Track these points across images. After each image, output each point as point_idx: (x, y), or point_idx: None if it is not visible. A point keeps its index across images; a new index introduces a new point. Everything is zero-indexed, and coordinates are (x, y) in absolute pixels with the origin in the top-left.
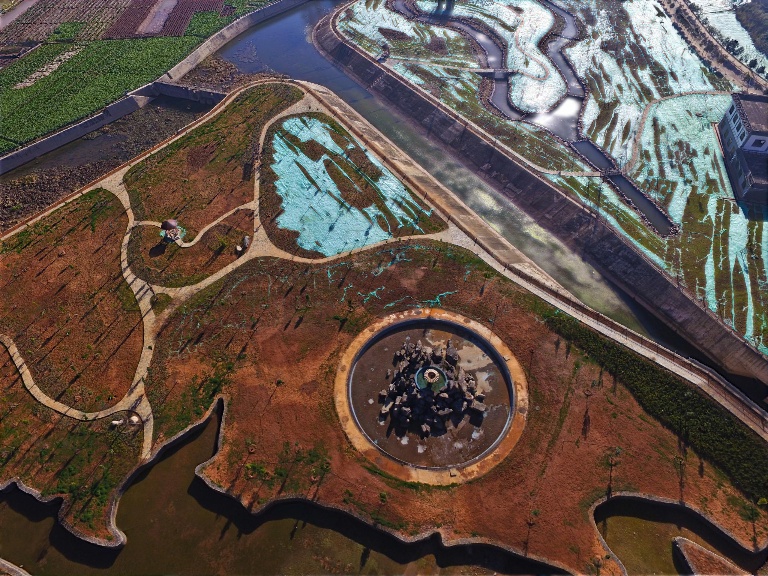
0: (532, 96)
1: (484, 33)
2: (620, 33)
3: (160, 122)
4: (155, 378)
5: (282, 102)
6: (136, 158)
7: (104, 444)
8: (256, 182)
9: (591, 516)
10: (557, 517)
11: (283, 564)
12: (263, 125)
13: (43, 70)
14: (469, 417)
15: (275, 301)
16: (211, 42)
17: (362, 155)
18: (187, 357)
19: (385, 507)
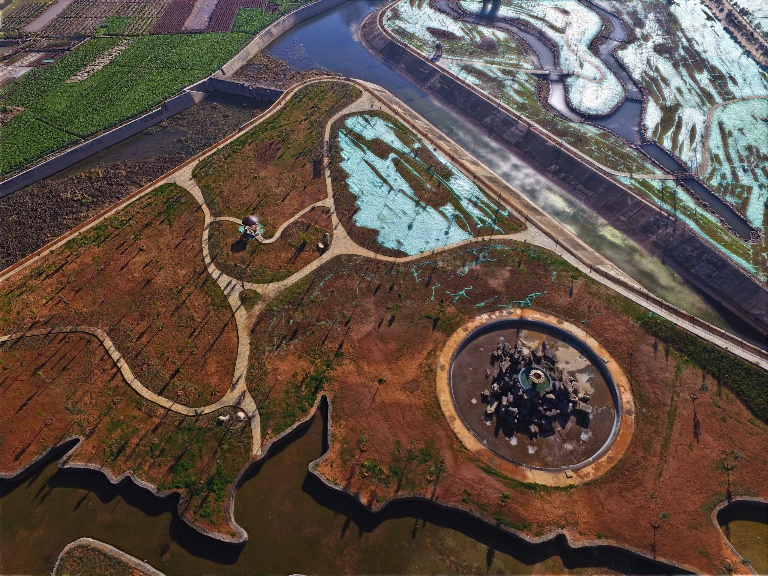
0: (591, 98)
1: (533, 34)
2: (672, 36)
3: (218, 118)
4: (255, 374)
5: (341, 100)
6: (202, 153)
7: (213, 439)
8: (328, 179)
9: (714, 520)
10: (681, 520)
11: (409, 563)
12: (326, 123)
13: (95, 64)
14: (575, 418)
15: (365, 299)
16: (260, 39)
17: (430, 154)
18: (284, 354)
19: (506, 507)
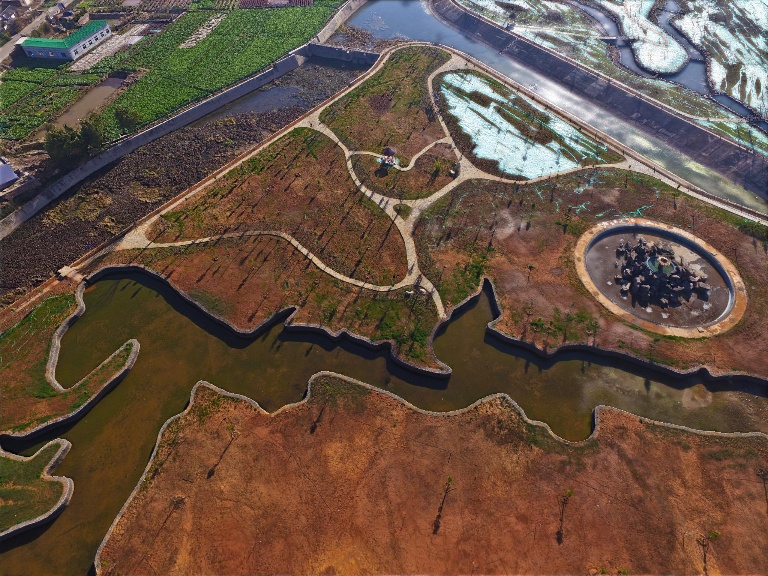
0: (660, 59)
1: (593, 7)
2: (724, 7)
3: (323, 78)
4: (425, 263)
5: (435, 61)
6: (322, 104)
7: (405, 307)
8: (442, 123)
9: None
10: None
11: (584, 389)
12: (426, 79)
13: (199, 33)
14: (696, 295)
15: (501, 210)
16: (343, 12)
17: (526, 103)
18: (445, 249)
19: (655, 351)
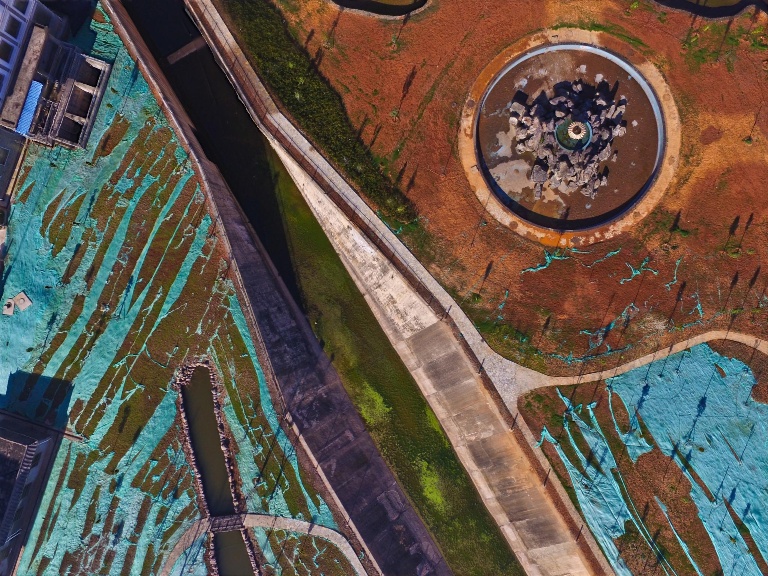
0: None
1: None
2: None
3: None
4: None
5: None
6: None
7: None
8: None
9: None
10: None
11: None
12: None
13: None
14: (527, 102)
15: None
16: None
17: None
18: None
19: (626, 7)
